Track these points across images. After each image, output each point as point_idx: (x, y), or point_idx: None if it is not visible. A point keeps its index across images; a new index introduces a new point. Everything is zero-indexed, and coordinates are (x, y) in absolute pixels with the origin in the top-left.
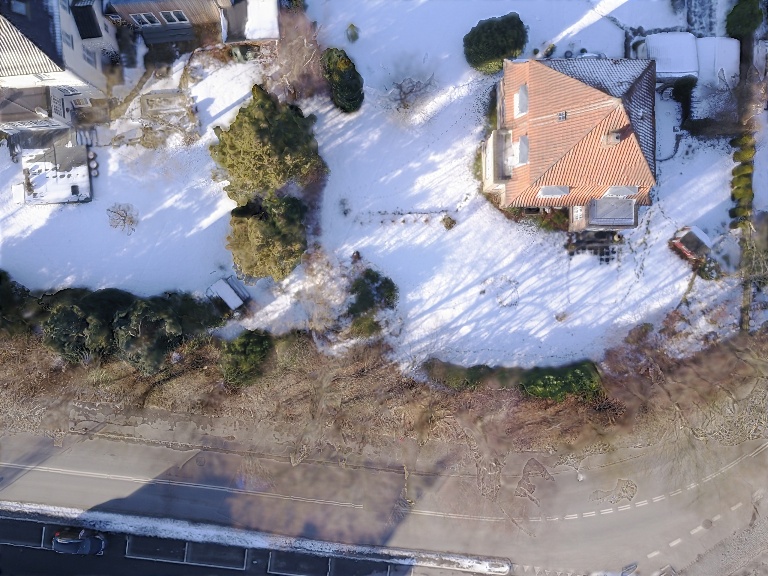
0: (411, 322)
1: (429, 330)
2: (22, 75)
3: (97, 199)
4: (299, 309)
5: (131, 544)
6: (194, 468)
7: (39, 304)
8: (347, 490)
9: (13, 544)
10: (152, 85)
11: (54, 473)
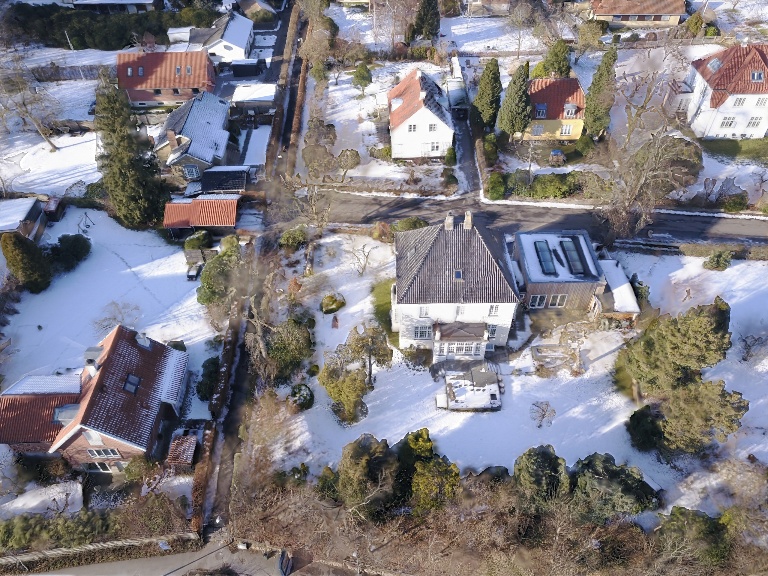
0: None
1: None
2: (491, 303)
3: (505, 409)
4: (710, 504)
5: None
6: None
7: (467, 480)
8: None
9: None
10: (538, 342)
11: None
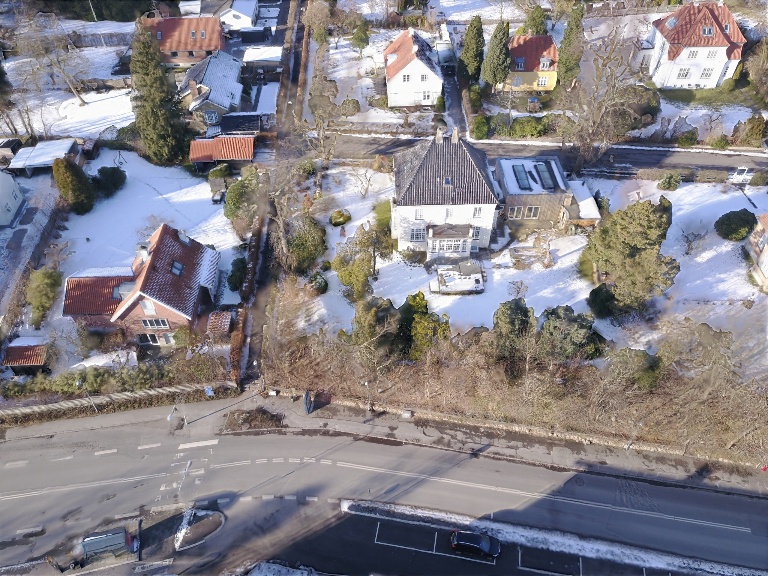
0: (746, 360)
1: (763, 366)
2: (475, 204)
3: (487, 292)
4: (652, 352)
5: (524, 555)
6: (575, 487)
7: None
8: (729, 513)
9: (406, 547)
10: (516, 245)
11: (446, 483)
